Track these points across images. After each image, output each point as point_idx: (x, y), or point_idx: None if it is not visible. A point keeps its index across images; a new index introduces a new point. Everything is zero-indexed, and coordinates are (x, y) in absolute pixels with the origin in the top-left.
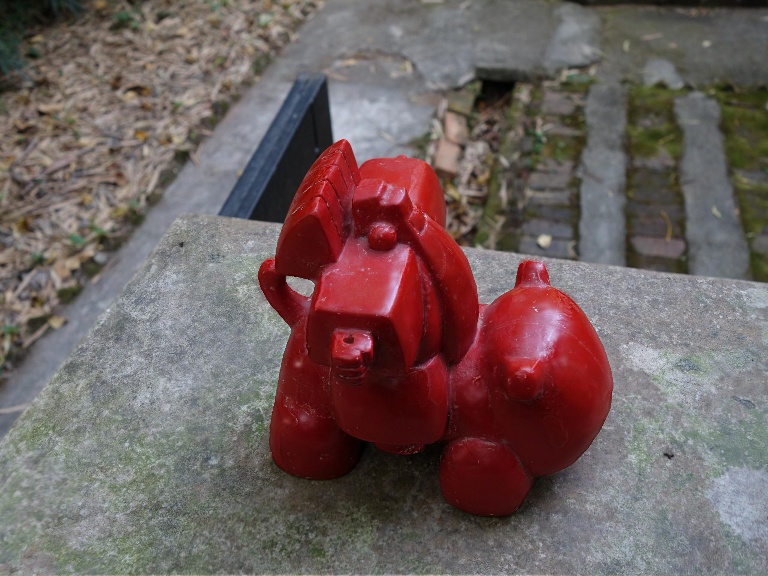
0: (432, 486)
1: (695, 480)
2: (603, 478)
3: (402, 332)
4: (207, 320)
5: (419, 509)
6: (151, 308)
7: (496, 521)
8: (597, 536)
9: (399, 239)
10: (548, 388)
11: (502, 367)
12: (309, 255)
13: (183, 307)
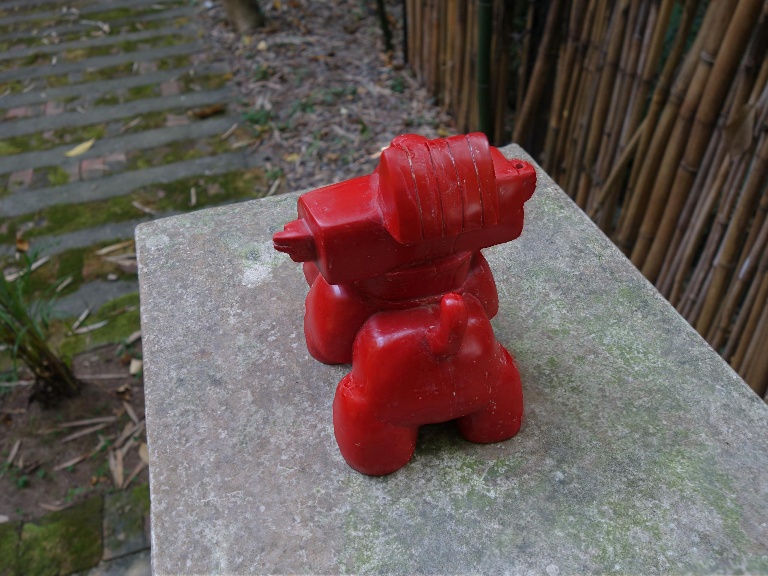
0: None
1: None
2: None
3: None
4: None
5: None
6: None
7: None
8: None
9: None
10: None
11: None
12: None
13: None
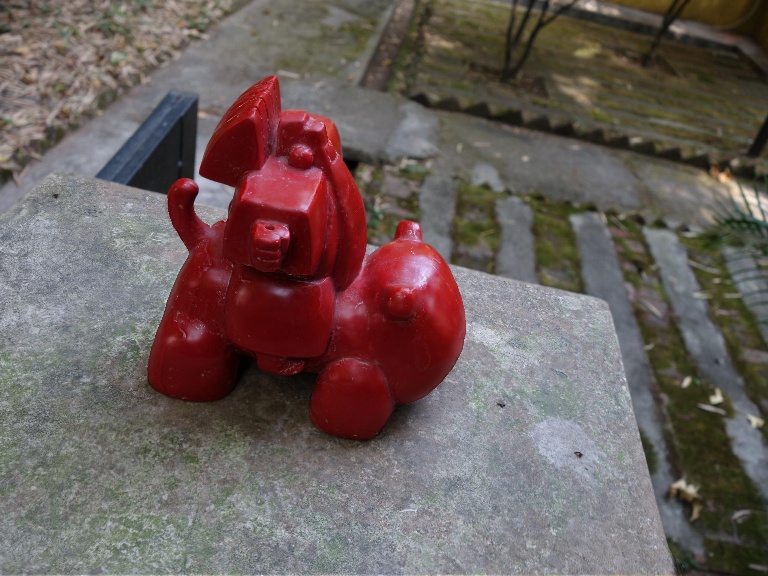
0: (302, 413)
1: (521, 424)
2: (449, 418)
3: (314, 232)
4: (82, 262)
5: (289, 430)
6: (20, 245)
7: (358, 443)
8: (443, 459)
9: (314, 163)
10: (420, 313)
11: (384, 292)
12: (237, 159)
13: (56, 248)
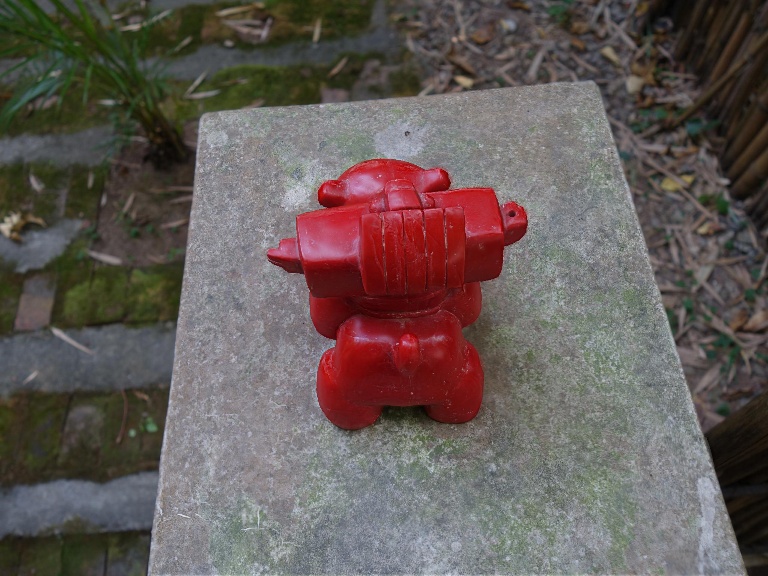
0: None
1: None
2: None
3: None
4: (334, 570)
5: None
6: None
7: None
8: None
9: None
10: None
11: None
12: None
13: None
